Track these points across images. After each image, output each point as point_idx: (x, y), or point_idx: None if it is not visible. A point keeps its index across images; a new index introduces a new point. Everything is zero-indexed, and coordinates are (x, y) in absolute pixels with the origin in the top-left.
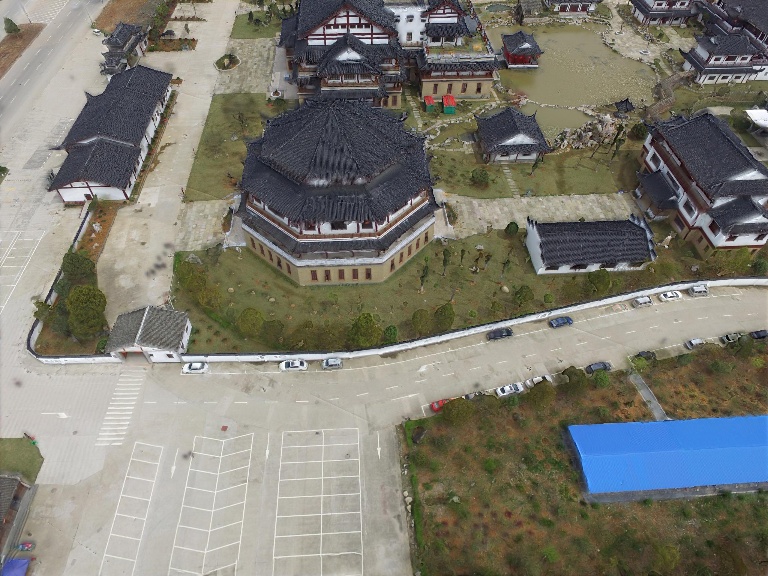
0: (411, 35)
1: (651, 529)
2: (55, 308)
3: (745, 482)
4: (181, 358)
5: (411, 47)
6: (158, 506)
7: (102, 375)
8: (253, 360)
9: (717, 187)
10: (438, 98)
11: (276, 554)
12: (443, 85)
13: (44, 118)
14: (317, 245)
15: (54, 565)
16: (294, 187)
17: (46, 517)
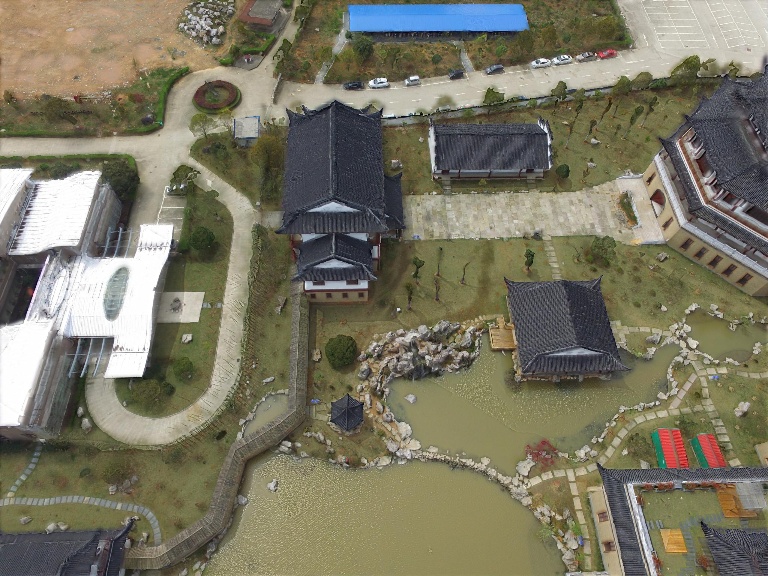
0: None
1: (487, 2)
2: None
3: (432, 4)
4: None
5: None
6: (762, 18)
7: None
8: None
9: None
10: None
11: (686, 1)
12: None
13: None
14: None
15: None
16: None
17: None
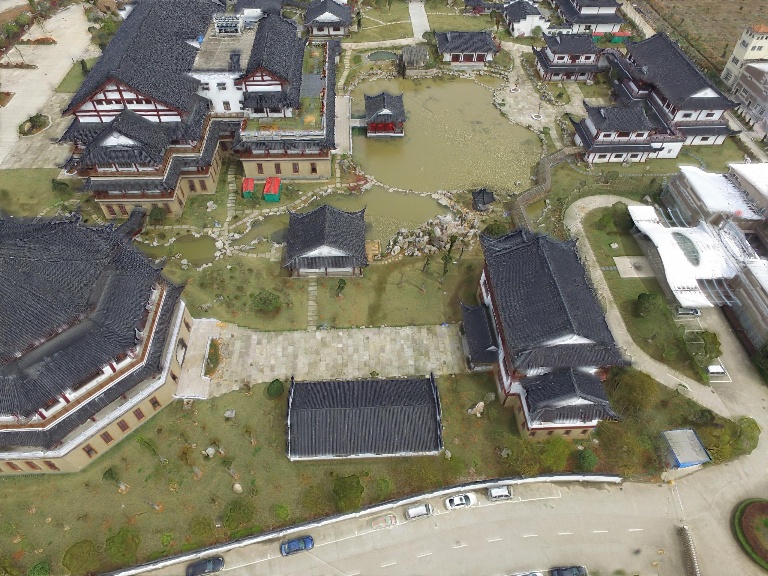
0: (229, 104)
1: None
2: None
3: None
4: None
5: (230, 118)
6: None
7: None
8: None
9: (525, 355)
10: None
11: None
12: (268, 165)
13: None
14: None
15: None
16: None
17: None
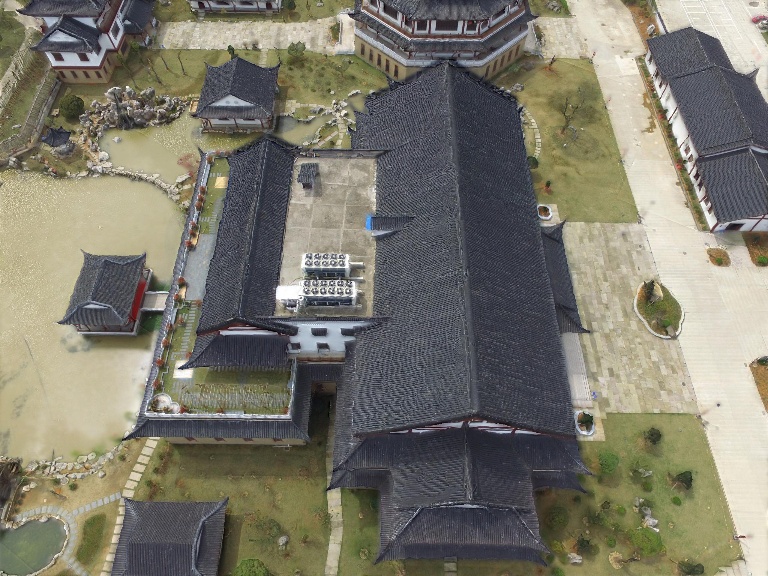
0: None
1: None
2: None
3: None
4: None
5: None
6: None
7: None
8: None
9: None
10: None
11: None
12: None
13: None
14: None
15: None
16: None
17: None
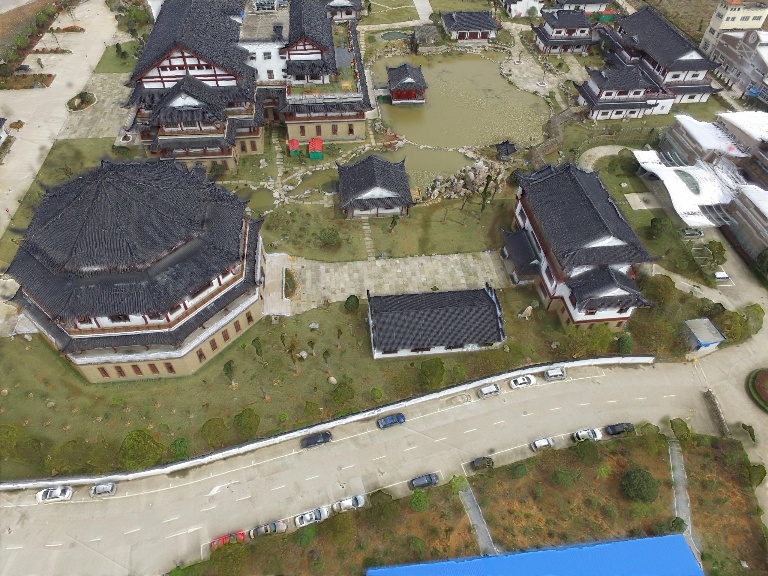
0: (272, 73)
1: None
2: None
3: None
4: None
5: (274, 86)
6: None
7: None
8: (7, 488)
9: (570, 256)
10: (308, 140)
11: None
12: (310, 127)
13: None
14: (95, 341)
15: None
16: None
17: None
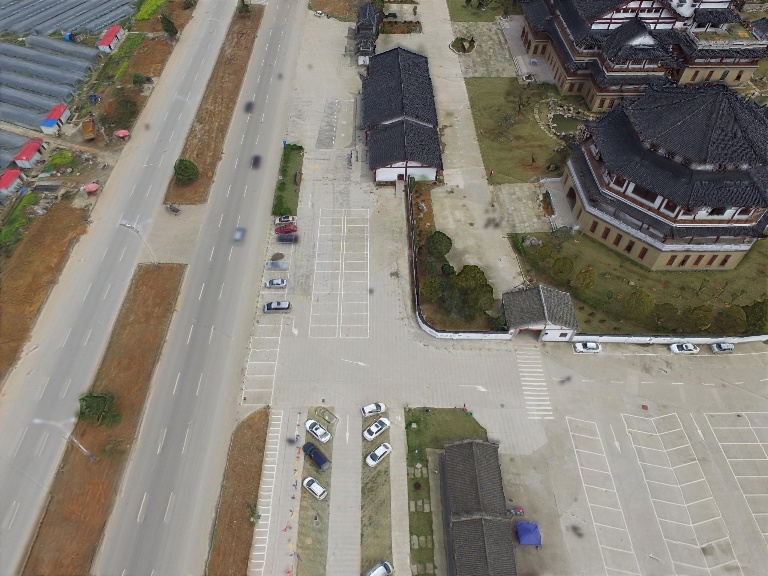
0: None
1: None
2: (438, 285)
3: None
4: (572, 337)
5: None
6: (622, 479)
7: (499, 351)
8: (639, 342)
9: None
10: (694, 85)
11: (762, 531)
12: (705, 72)
13: (310, 98)
14: (692, 230)
15: (550, 530)
16: (673, 172)
17: (518, 485)
